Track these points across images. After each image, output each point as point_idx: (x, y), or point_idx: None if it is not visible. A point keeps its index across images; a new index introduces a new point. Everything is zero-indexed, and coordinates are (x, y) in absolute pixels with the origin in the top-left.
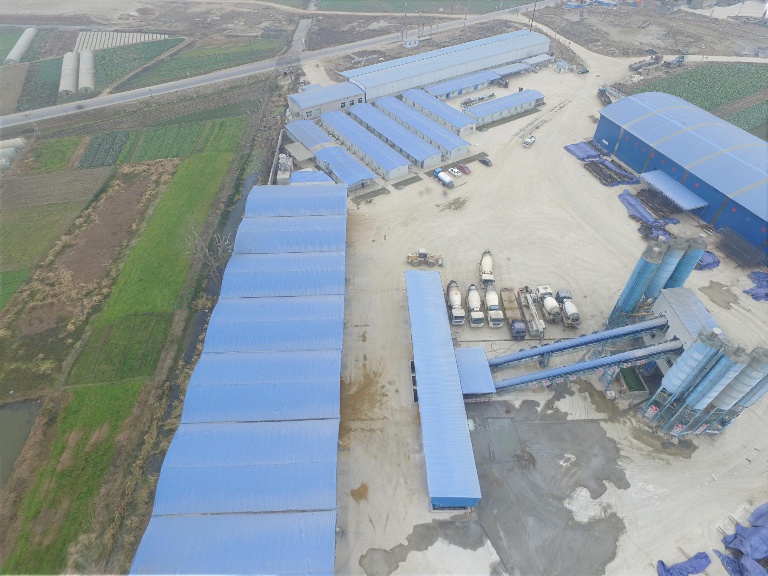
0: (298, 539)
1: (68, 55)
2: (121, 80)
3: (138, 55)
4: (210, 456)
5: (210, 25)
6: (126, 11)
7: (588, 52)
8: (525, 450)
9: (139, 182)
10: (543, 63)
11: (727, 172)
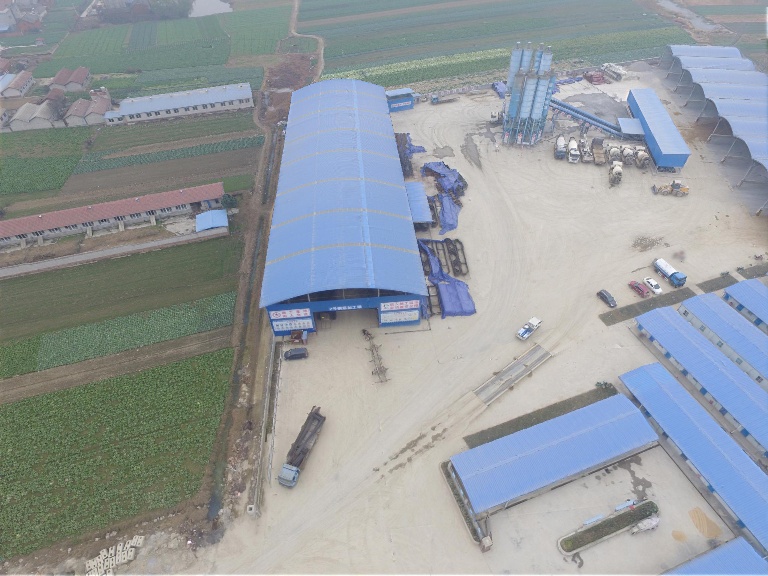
0: (706, 75)
1: None
2: None
3: None
4: (762, 89)
5: None
6: None
7: None
8: (599, 116)
9: None
10: None
11: (383, 167)
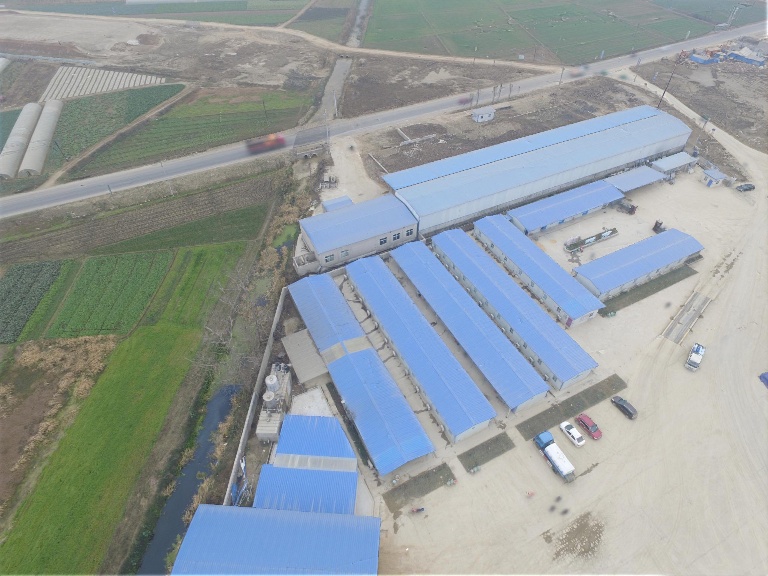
0: None
1: (27, 108)
2: (82, 156)
3: (118, 111)
4: None
5: (221, 65)
6: (123, 38)
7: (743, 147)
8: None
9: (38, 392)
10: (681, 167)
11: None
